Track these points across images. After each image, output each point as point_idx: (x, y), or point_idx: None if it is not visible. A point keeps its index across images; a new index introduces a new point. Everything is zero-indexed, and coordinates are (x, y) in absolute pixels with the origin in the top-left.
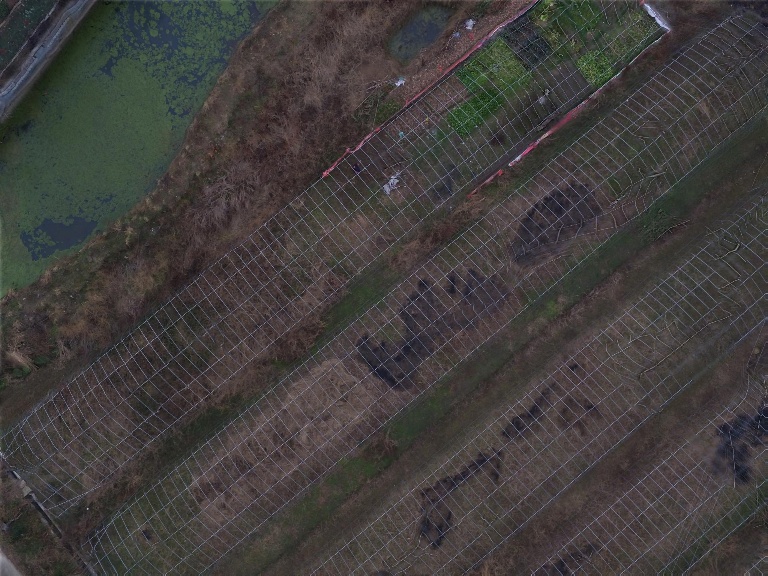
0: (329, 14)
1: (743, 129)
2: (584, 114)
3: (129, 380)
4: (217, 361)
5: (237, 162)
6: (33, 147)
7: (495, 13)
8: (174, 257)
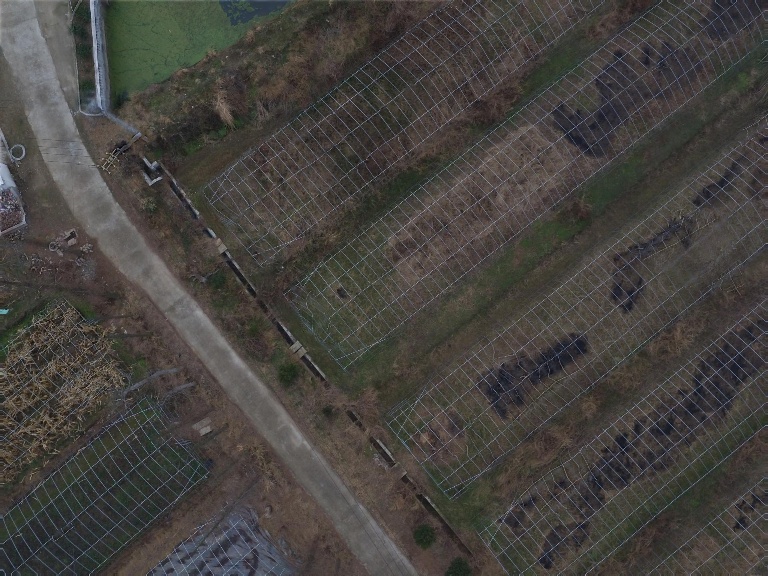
0: None
1: None
2: None
3: (340, 126)
4: (426, 112)
5: None
6: None
7: None
8: (375, 22)
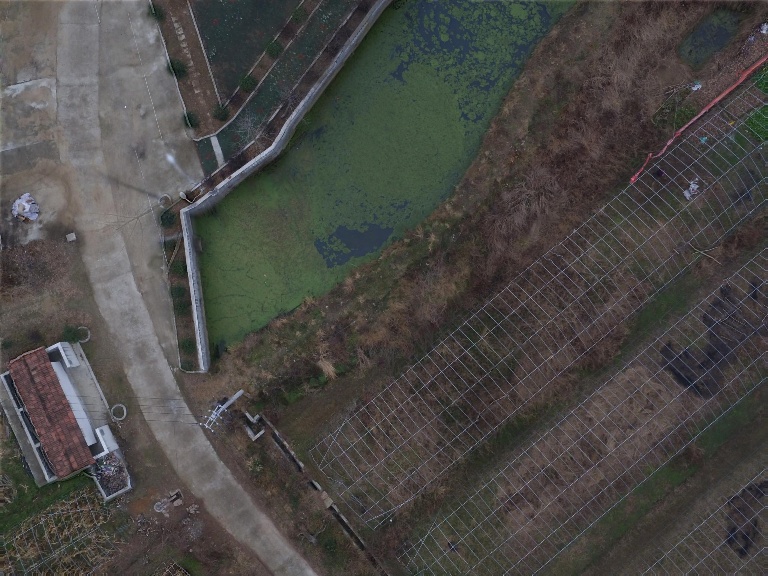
0: (628, 18)
1: None
2: None
3: (449, 389)
4: (535, 369)
5: (535, 167)
6: (325, 153)
7: None
8: (475, 264)
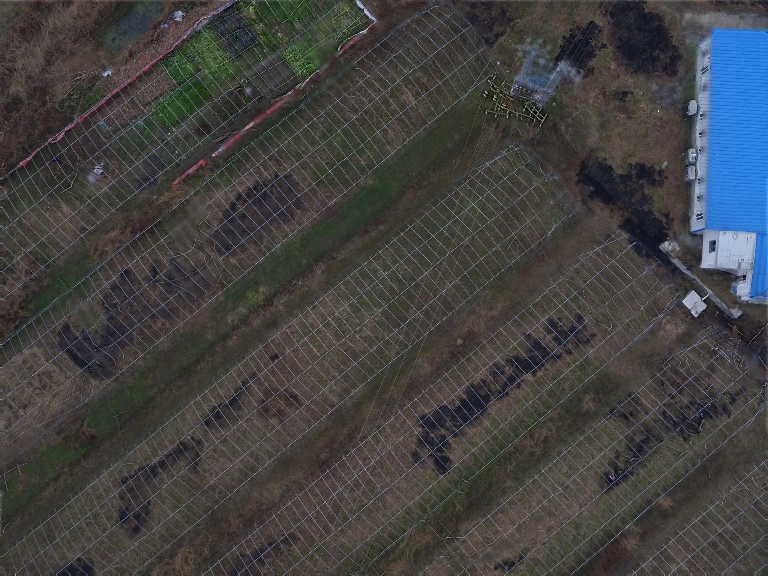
0: (34, 6)
1: (441, 118)
2: (289, 104)
3: None
4: None
5: None
6: None
7: (205, 5)
8: None
